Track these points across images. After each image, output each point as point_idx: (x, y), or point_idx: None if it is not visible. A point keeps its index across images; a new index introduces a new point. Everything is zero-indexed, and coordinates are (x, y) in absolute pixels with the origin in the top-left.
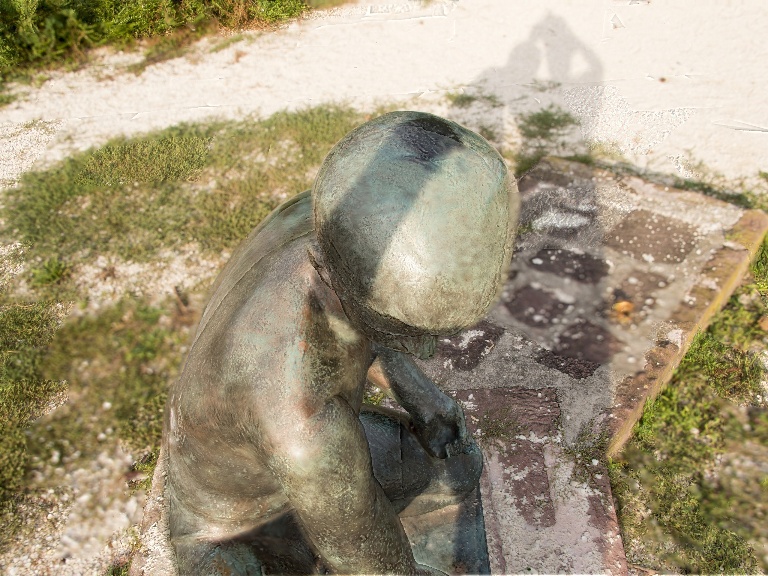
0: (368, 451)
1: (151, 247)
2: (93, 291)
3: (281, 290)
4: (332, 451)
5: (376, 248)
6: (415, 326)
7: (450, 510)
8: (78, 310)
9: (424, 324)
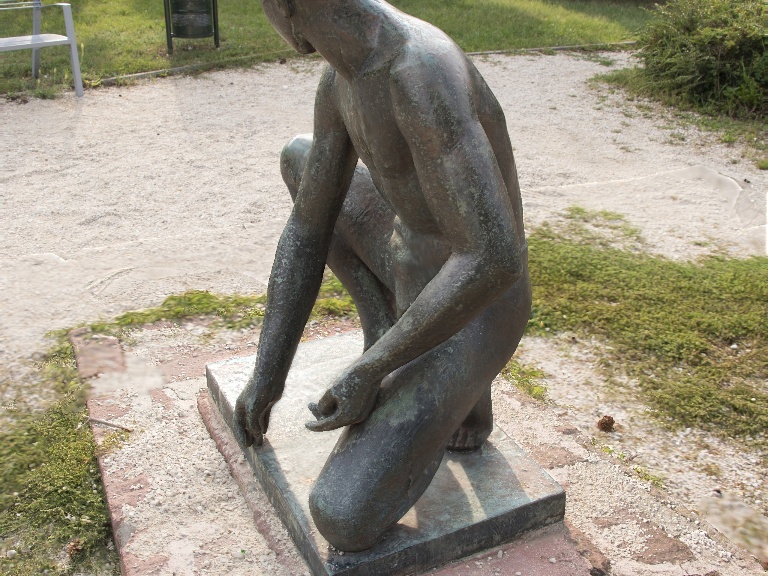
0: None
1: None
2: None
3: None
4: None
5: None
6: None
7: None
8: None
9: None
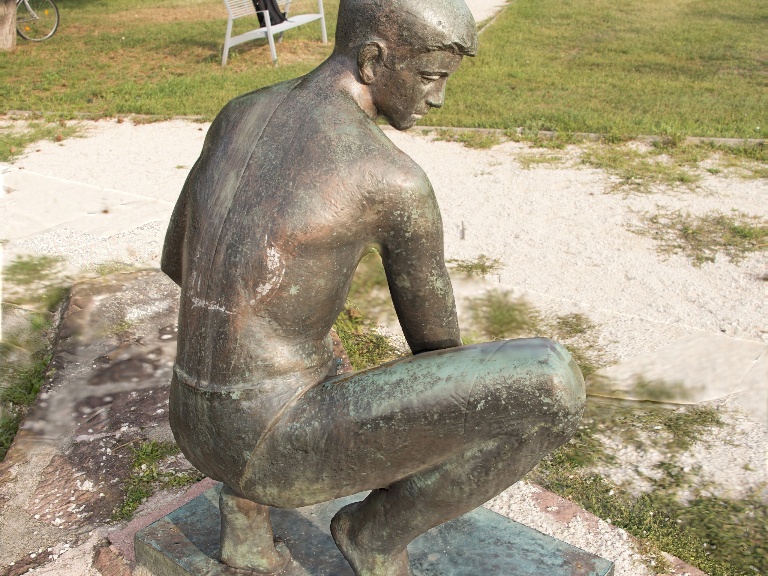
0: None
1: None
2: None
3: (330, 102)
4: None
5: (438, 0)
6: (467, 47)
7: None
8: None
9: (470, 45)
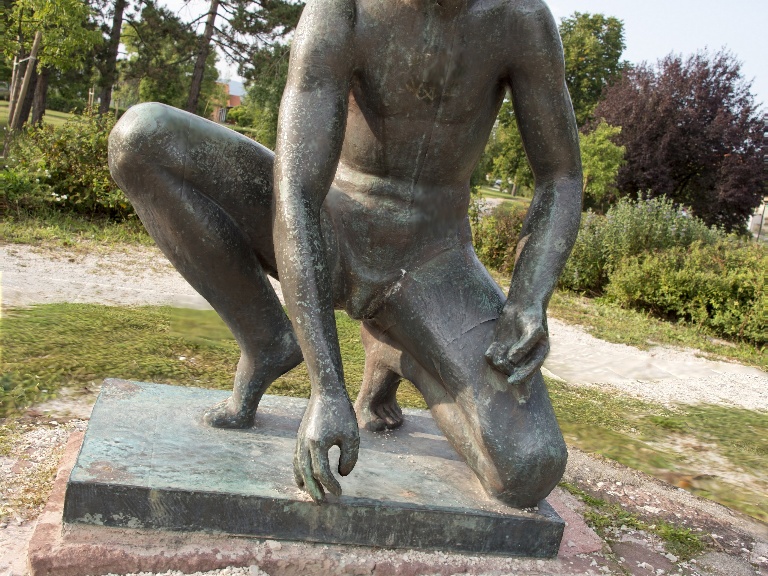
0: (333, 36)
1: (757, 463)
2: (668, 444)
3: None
4: (315, 5)
5: None
6: None
7: (481, 495)
8: (636, 437)
9: None
